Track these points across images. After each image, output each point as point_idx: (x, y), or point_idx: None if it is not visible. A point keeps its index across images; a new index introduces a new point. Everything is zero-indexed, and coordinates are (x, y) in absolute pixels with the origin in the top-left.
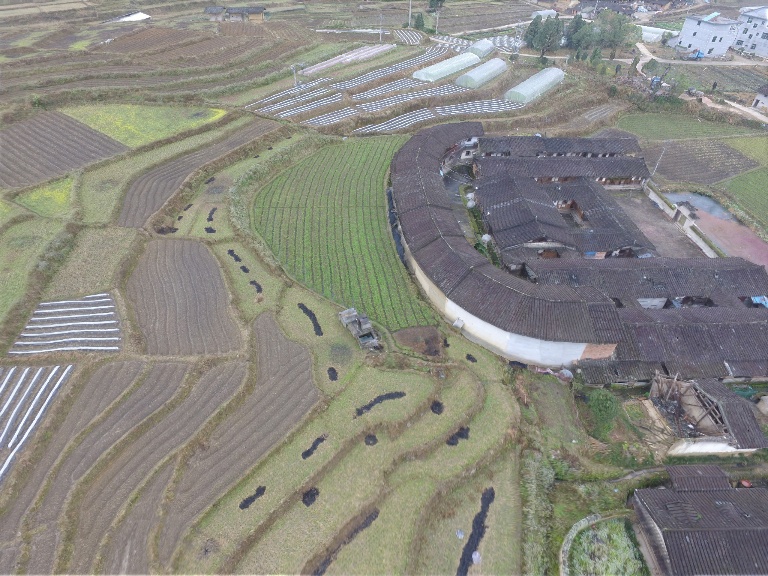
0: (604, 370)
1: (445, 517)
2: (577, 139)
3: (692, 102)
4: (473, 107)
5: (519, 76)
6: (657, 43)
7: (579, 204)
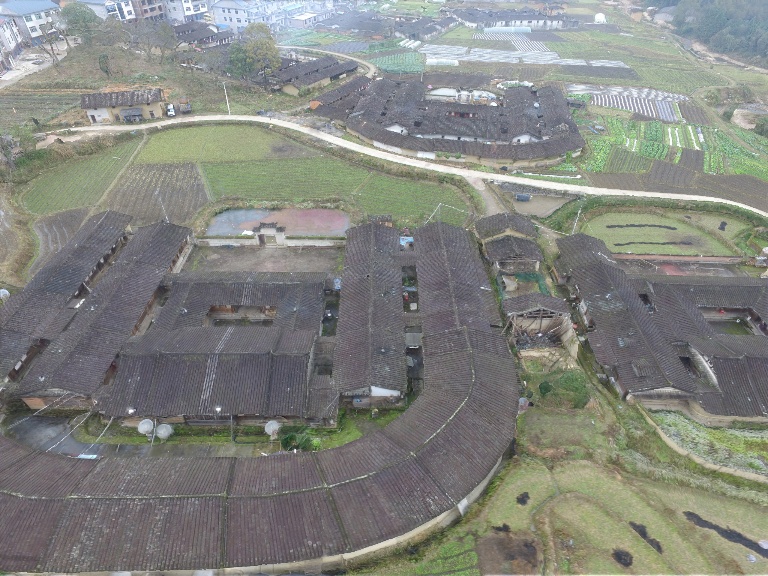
0: None
1: (742, 572)
2: (69, 256)
3: (56, 147)
4: None
5: None
6: None
7: (223, 304)
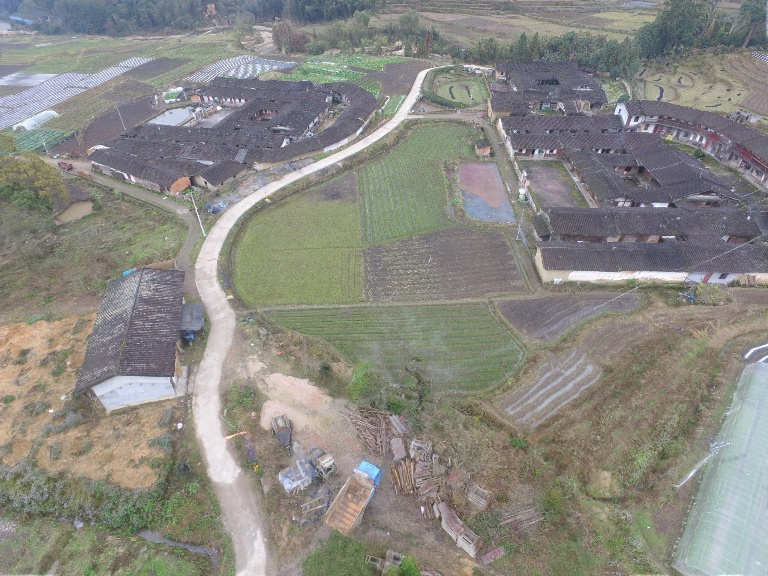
0: None
1: None
2: (629, 248)
3: (343, 373)
4: None
5: None
6: None
7: None
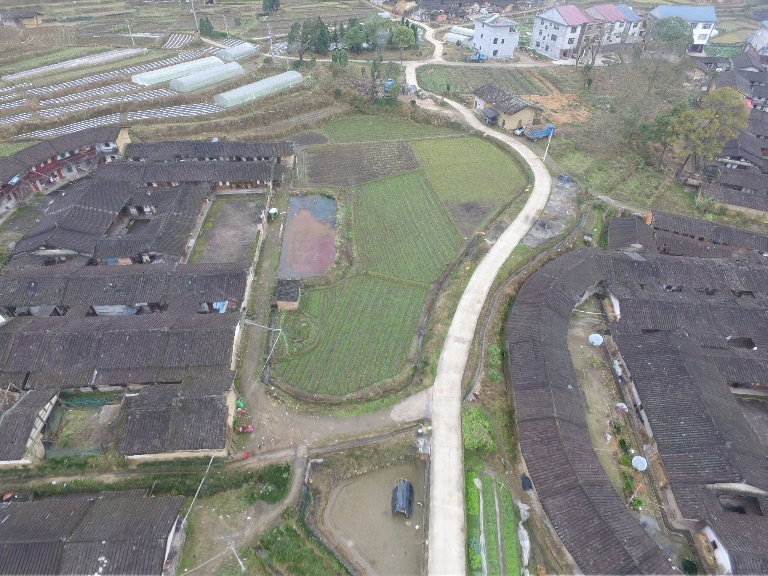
0: None
1: None
2: (231, 143)
3: (406, 104)
4: (171, 111)
5: (259, 79)
6: (465, 45)
7: None
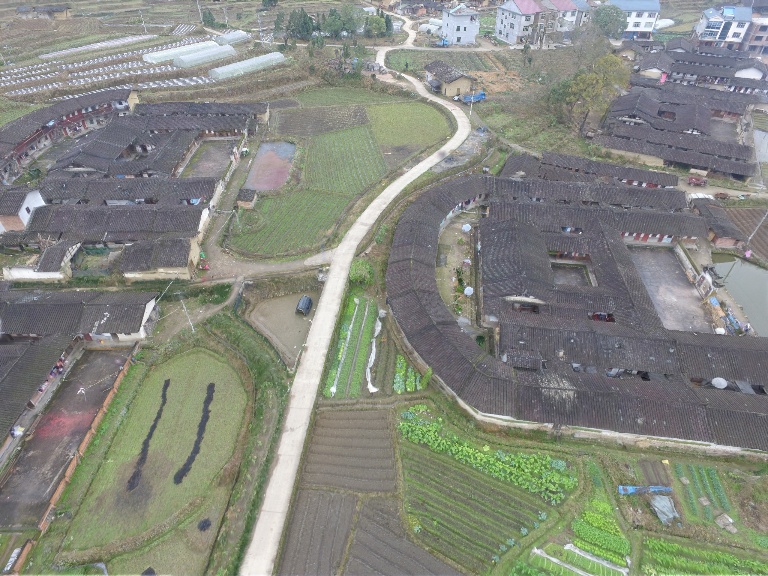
0: (18, 237)
1: None
2: (218, 103)
3: (367, 77)
4: (173, 82)
5: None
6: (437, 34)
7: None
